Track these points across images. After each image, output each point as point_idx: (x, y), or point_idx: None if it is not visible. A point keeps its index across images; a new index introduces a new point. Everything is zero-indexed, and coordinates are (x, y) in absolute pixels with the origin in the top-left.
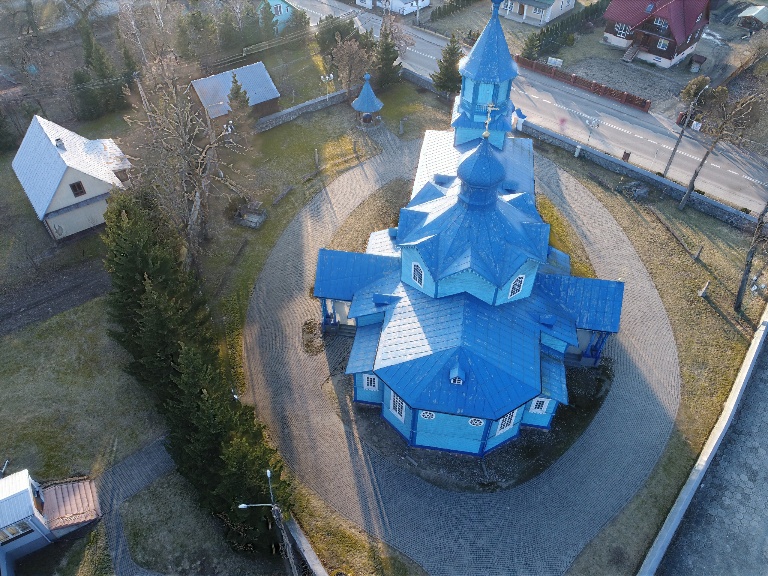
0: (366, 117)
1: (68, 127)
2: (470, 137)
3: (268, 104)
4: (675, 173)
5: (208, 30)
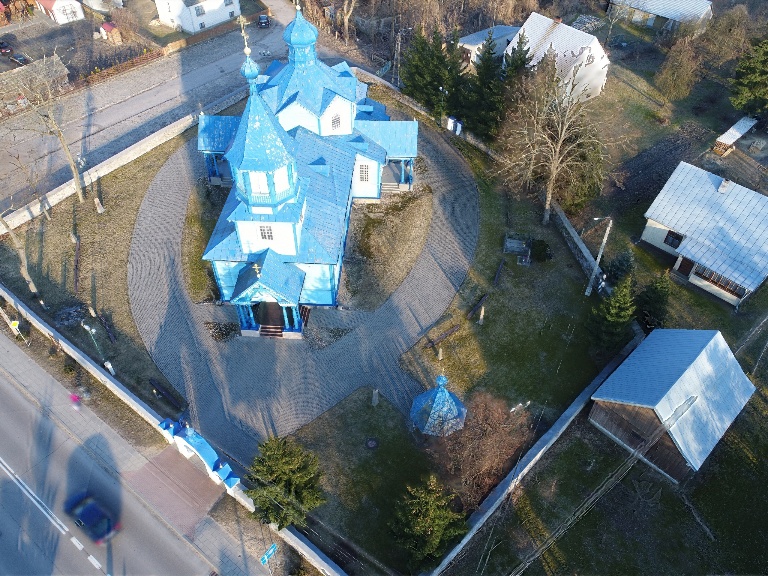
0: None
1: None
2: None
3: None
4: None
5: None
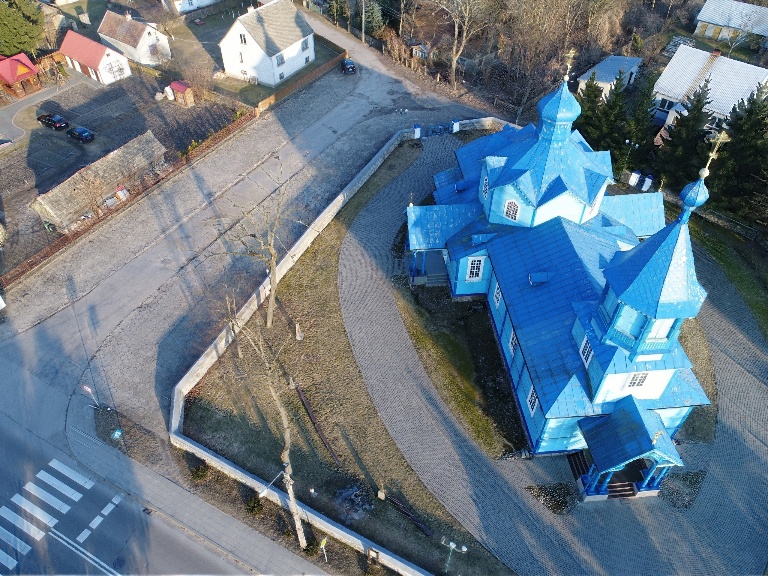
0: None
1: None
2: None
3: None
4: (279, 569)
5: None
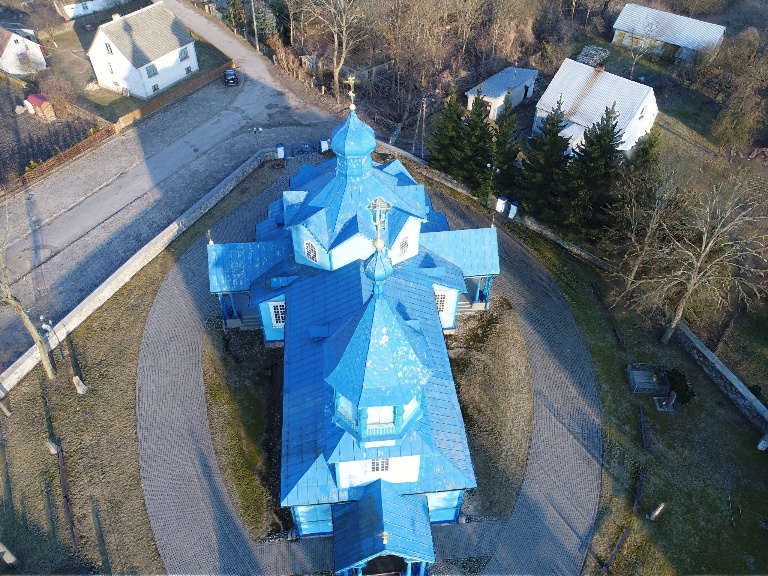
0: None
1: None
2: None
3: None
4: None
5: None
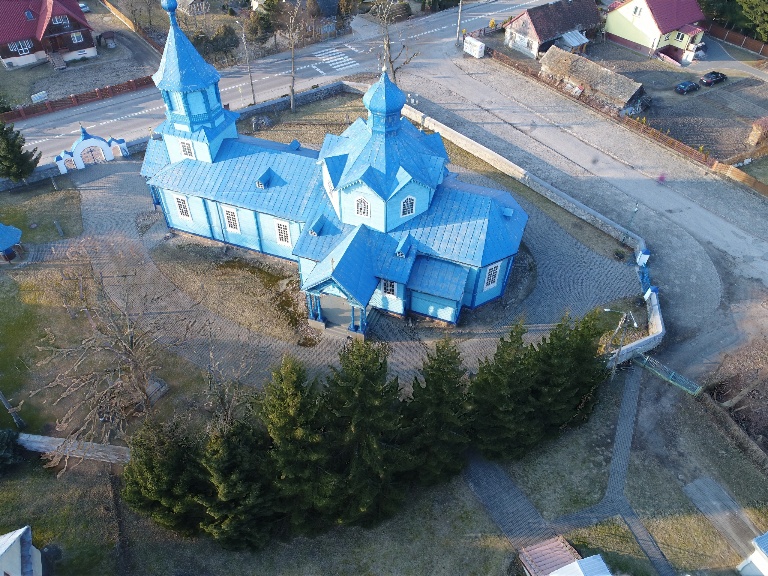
0: (9, 252)
1: None
2: (218, 144)
3: None
4: None
5: None
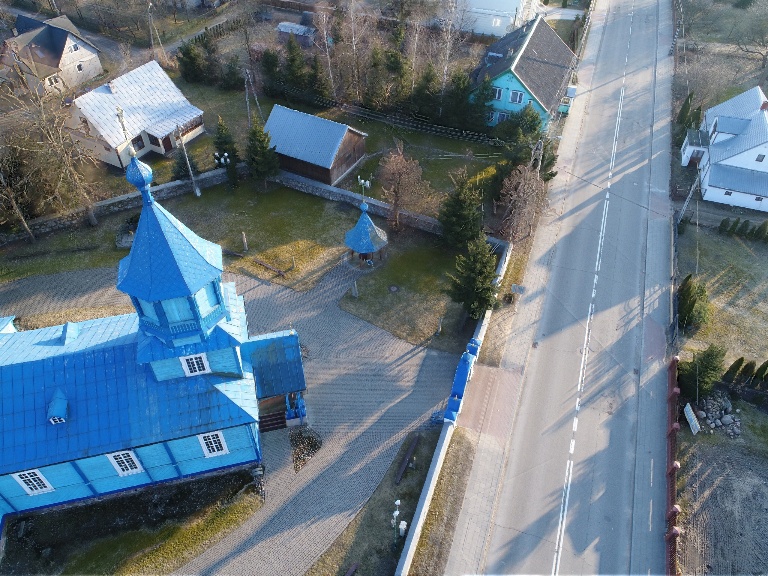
0: None
1: (252, 92)
2: None
3: (320, 169)
4: None
5: (398, 75)
